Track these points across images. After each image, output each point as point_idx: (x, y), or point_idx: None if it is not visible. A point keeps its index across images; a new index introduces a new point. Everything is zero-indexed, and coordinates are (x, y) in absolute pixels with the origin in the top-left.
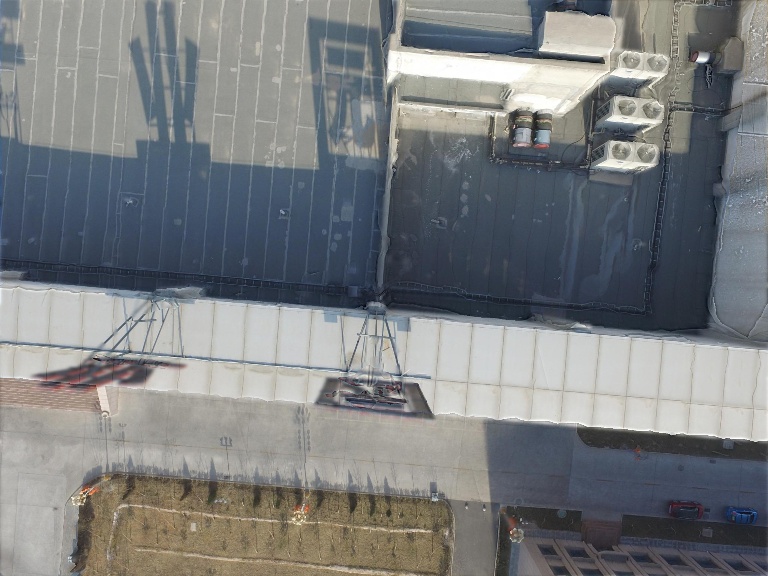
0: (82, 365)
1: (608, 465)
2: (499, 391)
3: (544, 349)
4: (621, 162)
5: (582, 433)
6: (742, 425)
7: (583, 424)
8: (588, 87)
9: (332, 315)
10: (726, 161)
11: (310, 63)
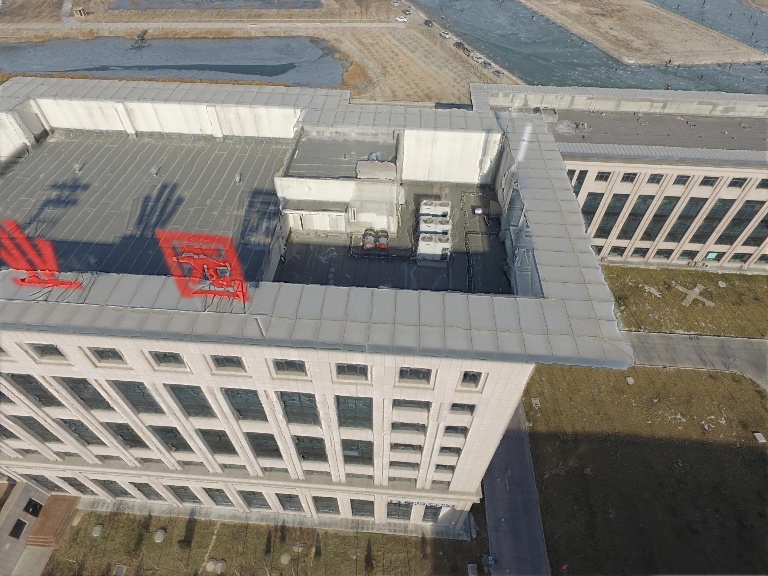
0: (4, 308)
1: None
2: (319, 322)
3: (356, 298)
4: (429, 244)
5: None
6: (516, 343)
7: (386, 344)
8: (394, 201)
9: (204, 281)
10: (508, 255)
11: (237, 207)
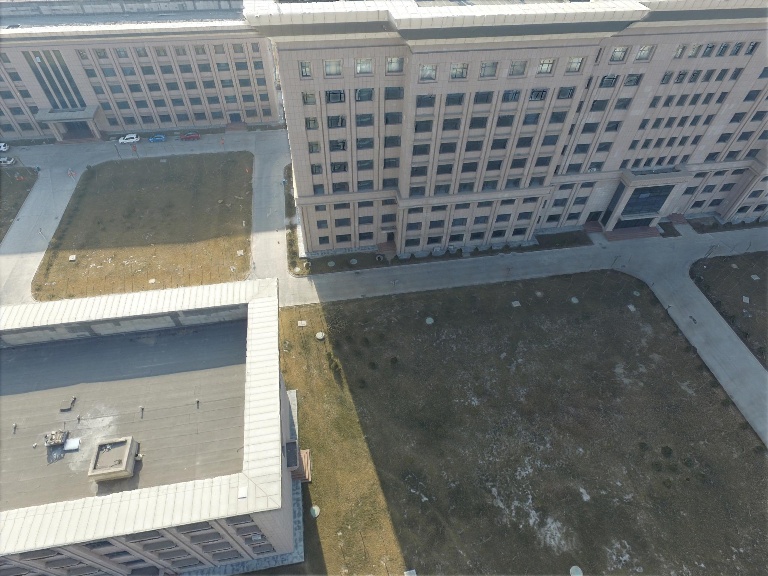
0: None
1: (234, 146)
2: None
3: None
4: None
5: (251, 154)
6: None
7: None
8: None
9: None
10: None
11: None
